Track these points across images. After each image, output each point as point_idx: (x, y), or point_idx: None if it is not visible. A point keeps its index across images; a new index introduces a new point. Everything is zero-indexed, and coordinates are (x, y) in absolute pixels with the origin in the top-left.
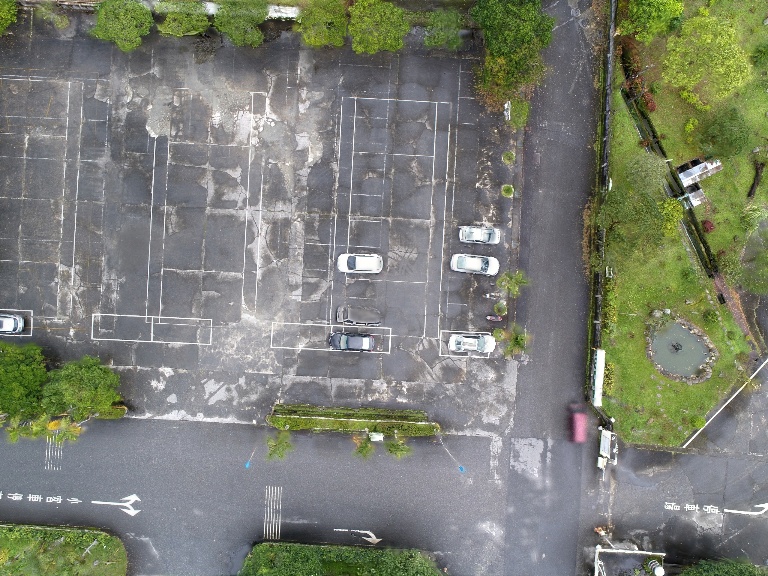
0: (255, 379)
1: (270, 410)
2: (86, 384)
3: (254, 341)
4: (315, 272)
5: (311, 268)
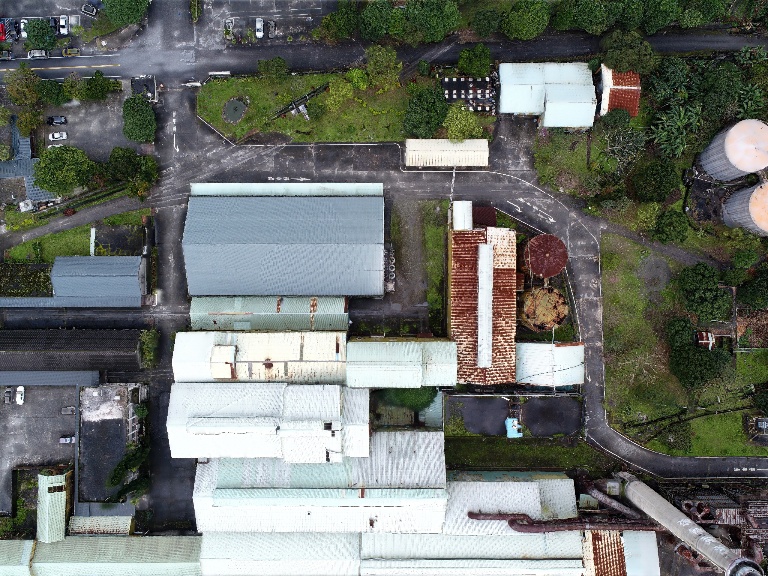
0: None
1: None
2: None
3: None
4: None
5: None
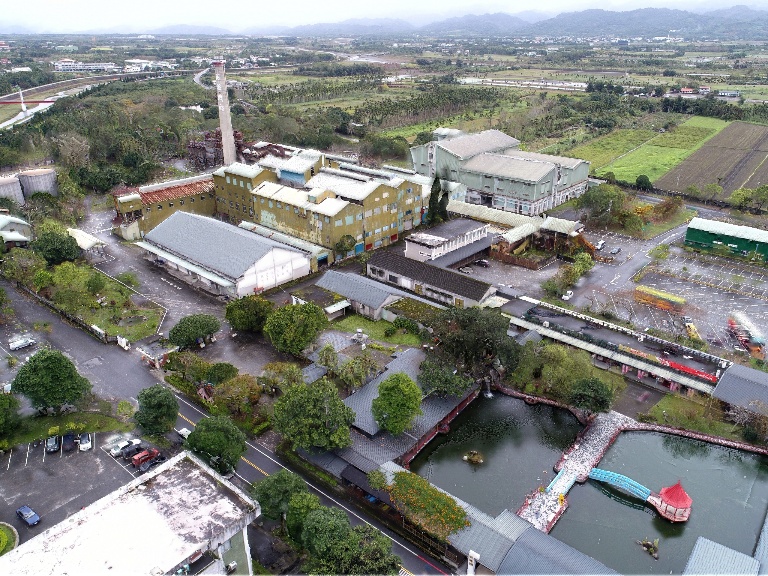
0: None
1: None
2: None
3: None
4: None
5: None
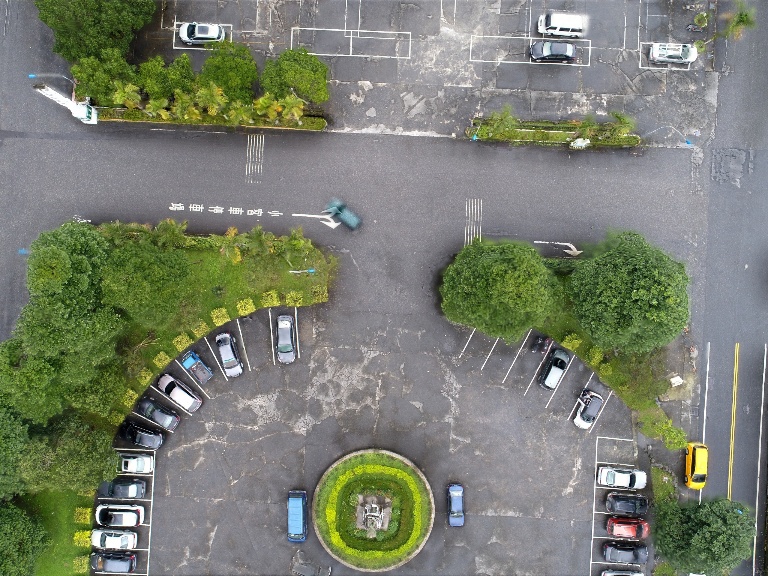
0: (454, 92)
1: (469, 123)
2: (305, 68)
3: (453, 54)
4: None
5: None
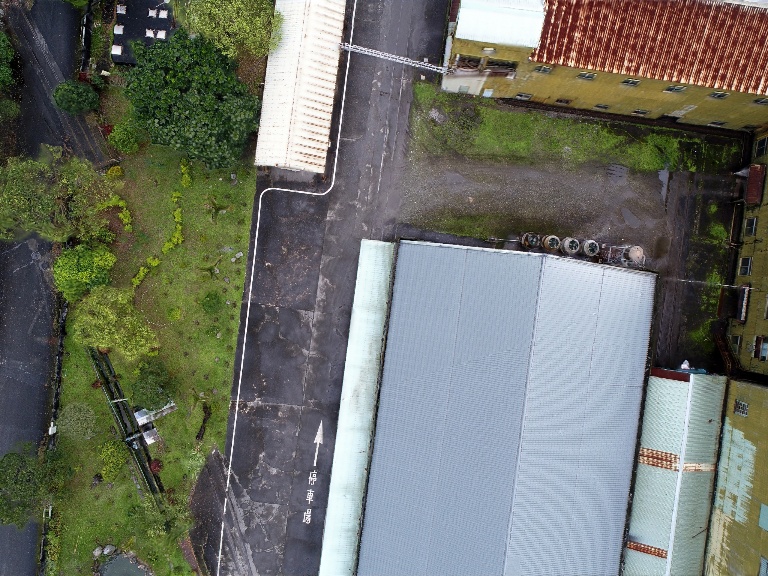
0: None
1: None
2: None
3: None
4: None
5: None
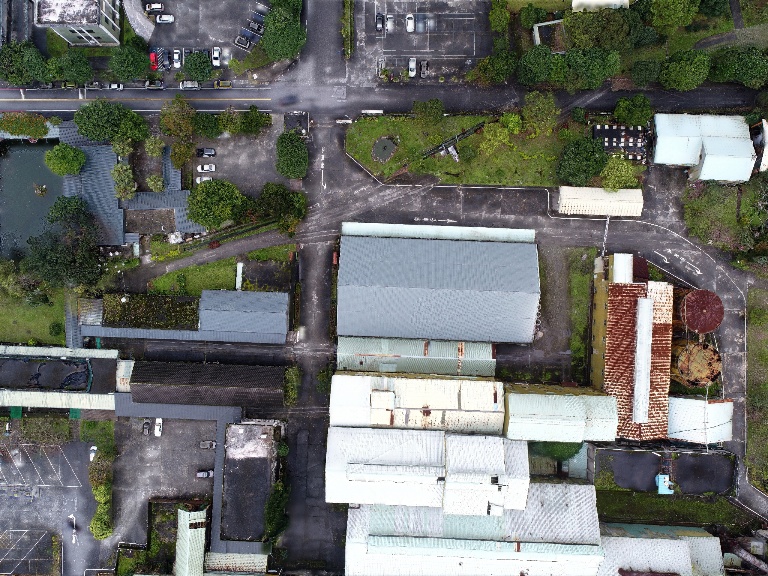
0: None
1: None
2: None
3: None
4: (406, 7)
5: (407, 5)
